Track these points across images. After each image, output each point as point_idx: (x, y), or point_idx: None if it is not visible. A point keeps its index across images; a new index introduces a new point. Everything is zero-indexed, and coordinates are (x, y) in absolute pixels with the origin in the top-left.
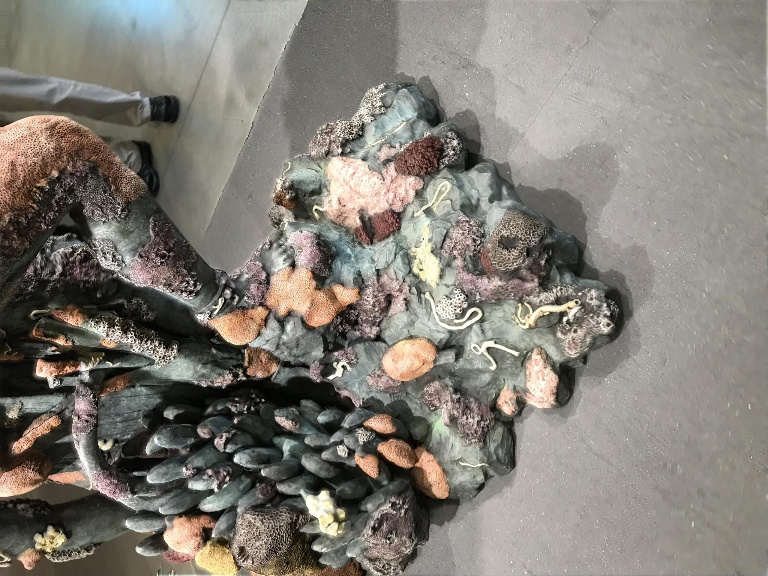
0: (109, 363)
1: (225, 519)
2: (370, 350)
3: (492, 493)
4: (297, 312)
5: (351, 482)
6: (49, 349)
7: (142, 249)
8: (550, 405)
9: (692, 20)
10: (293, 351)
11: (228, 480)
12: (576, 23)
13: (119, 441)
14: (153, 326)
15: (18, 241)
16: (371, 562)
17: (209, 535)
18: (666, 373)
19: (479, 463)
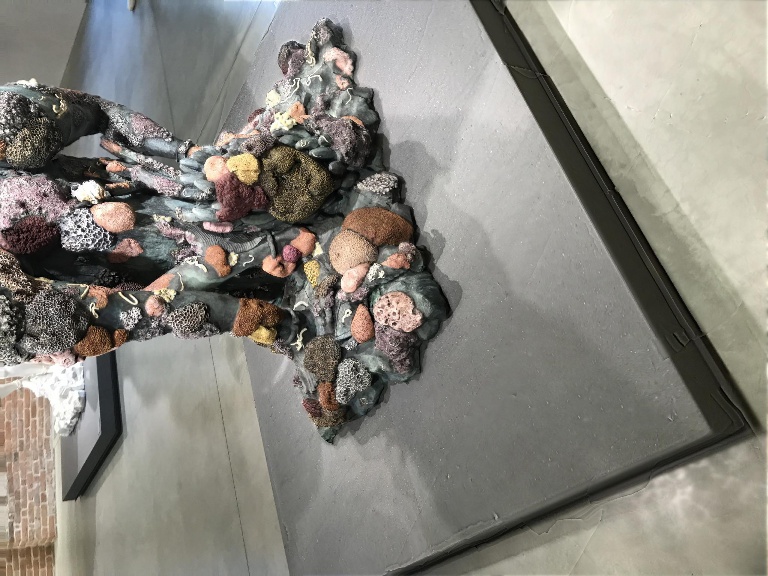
0: None
1: None
2: None
3: (380, 106)
4: None
5: None
6: None
7: None
8: (350, 60)
9: None
10: None
11: None
12: (273, 58)
13: None
14: None
15: None
16: (343, 145)
17: None
18: (354, 4)
19: None
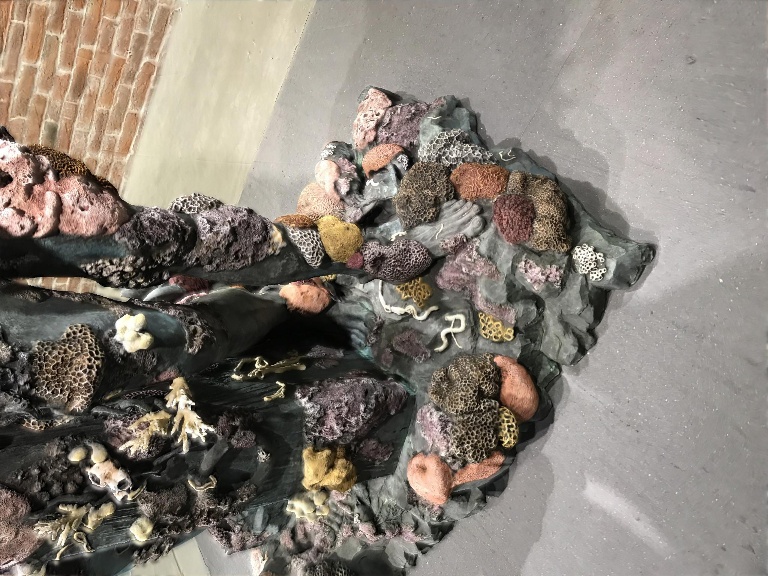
0: None
1: None
2: None
3: None
4: None
5: None
6: None
7: None
8: None
9: (222, 575)
10: None
11: None
12: None
13: None
14: None
15: None
16: None
17: None
18: None
19: None
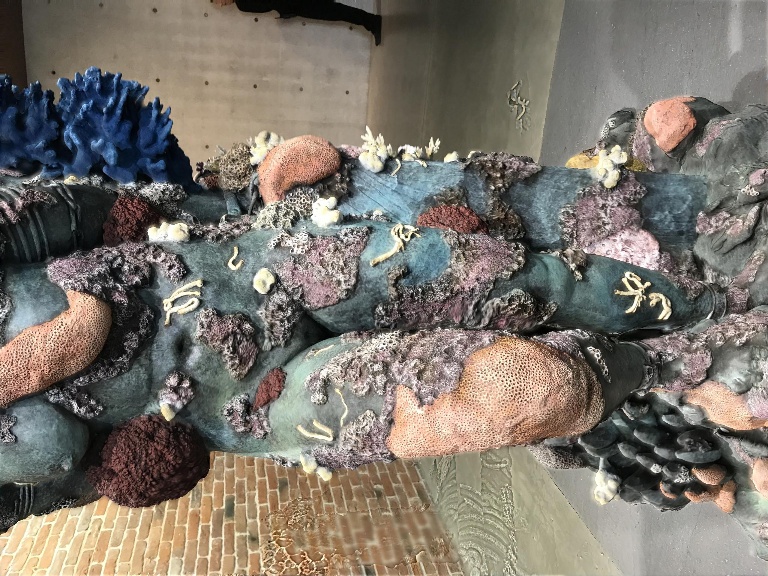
0: None
1: None
2: (757, 448)
3: None
4: (707, 412)
5: (644, 486)
6: None
7: None
8: None
9: None
10: None
11: None
12: None
13: None
14: None
15: None
16: None
17: None
18: None
19: (760, 557)
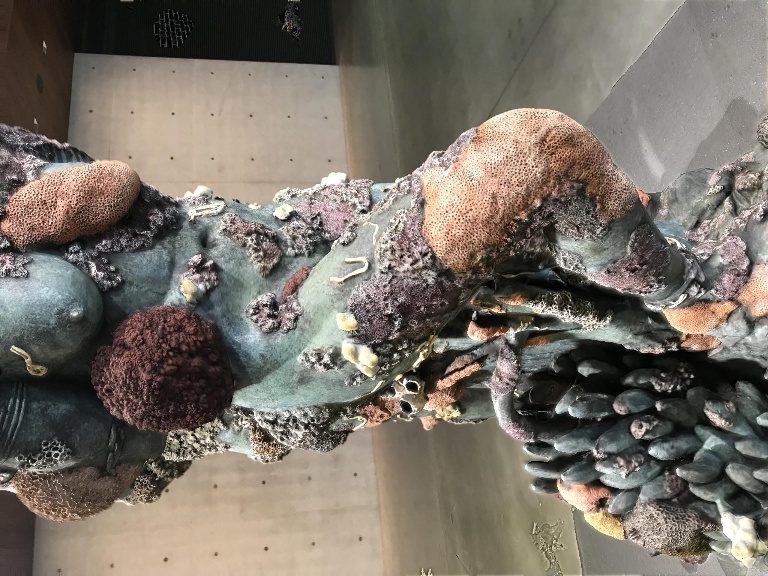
0: (536, 327)
1: (624, 499)
2: None
3: None
4: None
5: None
6: (482, 310)
7: (612, 265)
8: None
9: None
10: (754, 352)
11: (638, 470)
12: None
13: (526, 372)
14: (589, 293)
15: (484, 273)
16: None
17: (603, 502)
18: None
19: None
